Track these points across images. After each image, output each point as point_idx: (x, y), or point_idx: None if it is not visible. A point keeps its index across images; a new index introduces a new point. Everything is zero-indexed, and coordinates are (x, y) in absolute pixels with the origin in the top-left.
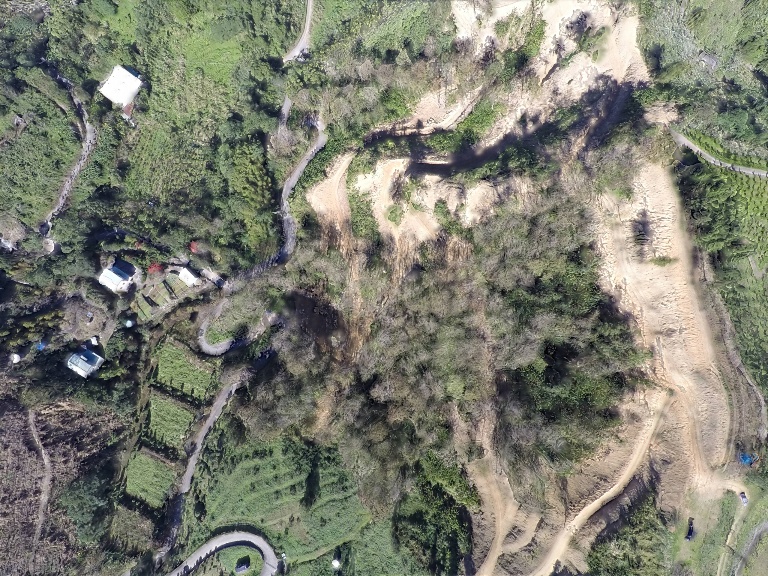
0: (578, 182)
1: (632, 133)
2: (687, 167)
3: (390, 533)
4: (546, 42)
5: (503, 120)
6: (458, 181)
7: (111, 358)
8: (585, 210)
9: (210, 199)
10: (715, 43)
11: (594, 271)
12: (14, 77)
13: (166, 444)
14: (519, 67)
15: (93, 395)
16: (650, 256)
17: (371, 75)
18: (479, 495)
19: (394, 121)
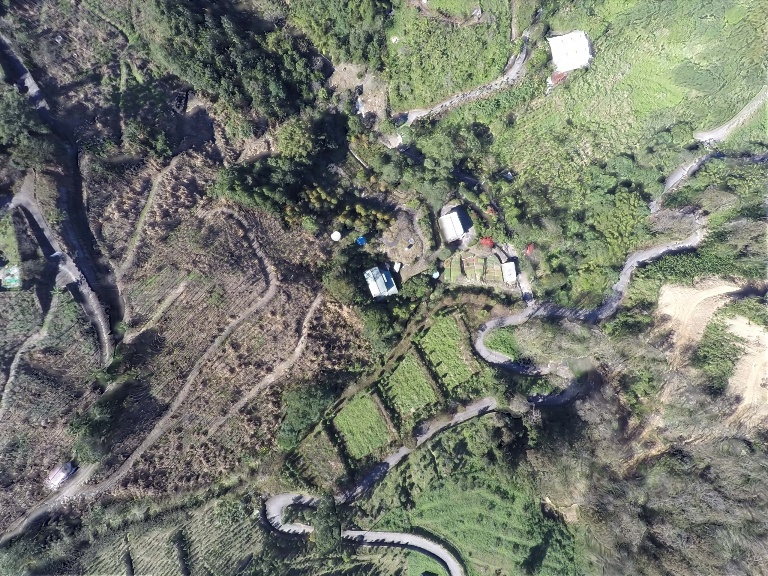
0: None
1: None
2: None
3: None
4: None
5: None
6: None
7: (406, 296)
8: None
9: (564, 213)
10: None
11: None
12: None
13: (394, 405)
14: None
15: (381, 323)
16: None
17: None
18: None
19: None
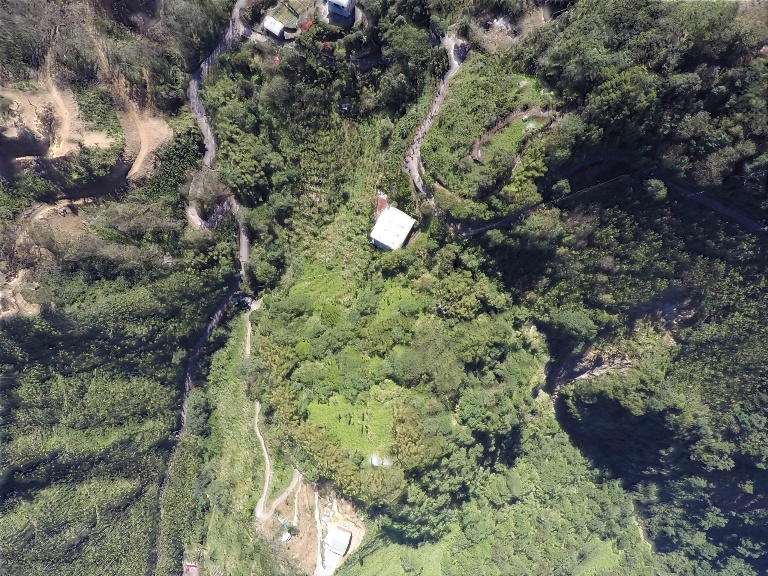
0: None
1: None
2: None
3: None
4: None
5: None
6: None
7: None
8: None
9: None
10: None
11: None
12: (488, 204)
13: None
14: None
15: None
16: None
17: None
18: None
19: None
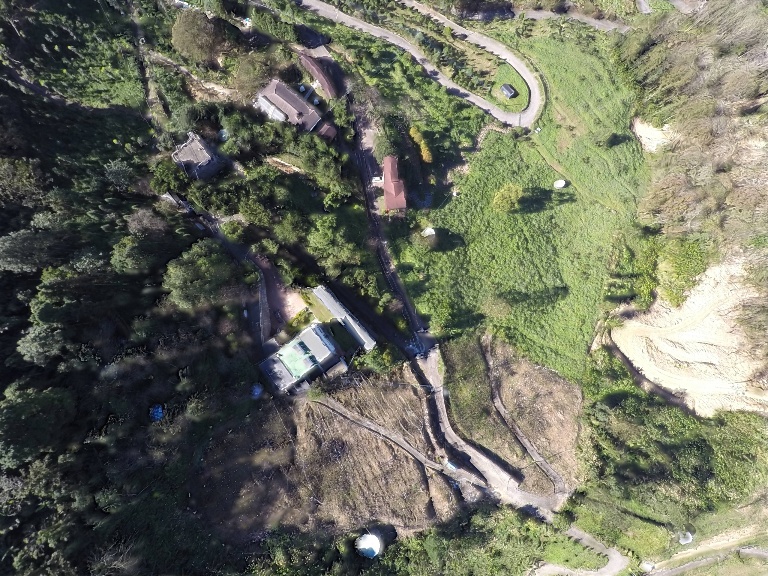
0: None
1: None
2: None
3: (610, 229)
4: None
5: None
6: None
7: None
8: None
9: None
10: None
11: None
12: None
13: None
14: None
15: None
16: None
17: None
18: (683, 303)
19: None
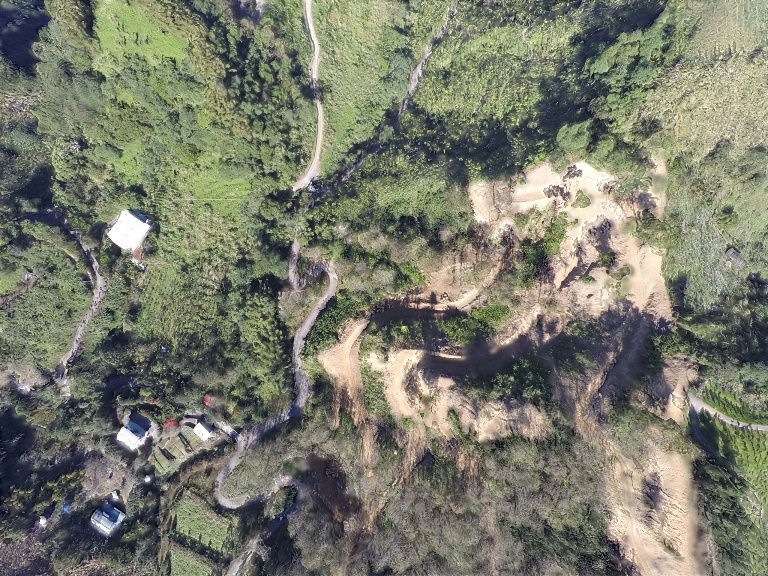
0: (592, 440)
1: (650, 427)
2: (704, 463)
3: None
4: (567, 242)
5: (519, 321)
6: (471, 402)
7: (132, 514)
8: (598, 475)
9: (222, 346)
10: (744, 233)
11: (603, 534)
12: (22, 232)
13: None
14: (538, 263)
15: (117, 556)
16: (660, 541)
17: (385, 251)
18: None
19: (407, 288)
